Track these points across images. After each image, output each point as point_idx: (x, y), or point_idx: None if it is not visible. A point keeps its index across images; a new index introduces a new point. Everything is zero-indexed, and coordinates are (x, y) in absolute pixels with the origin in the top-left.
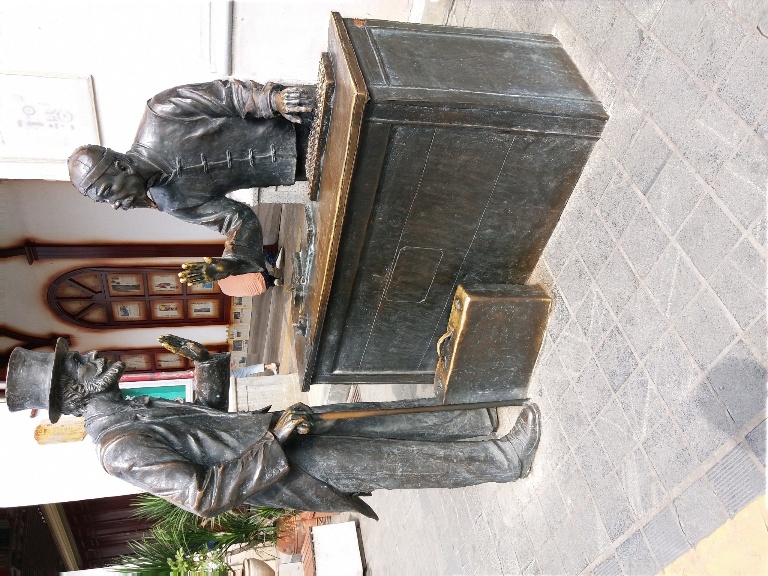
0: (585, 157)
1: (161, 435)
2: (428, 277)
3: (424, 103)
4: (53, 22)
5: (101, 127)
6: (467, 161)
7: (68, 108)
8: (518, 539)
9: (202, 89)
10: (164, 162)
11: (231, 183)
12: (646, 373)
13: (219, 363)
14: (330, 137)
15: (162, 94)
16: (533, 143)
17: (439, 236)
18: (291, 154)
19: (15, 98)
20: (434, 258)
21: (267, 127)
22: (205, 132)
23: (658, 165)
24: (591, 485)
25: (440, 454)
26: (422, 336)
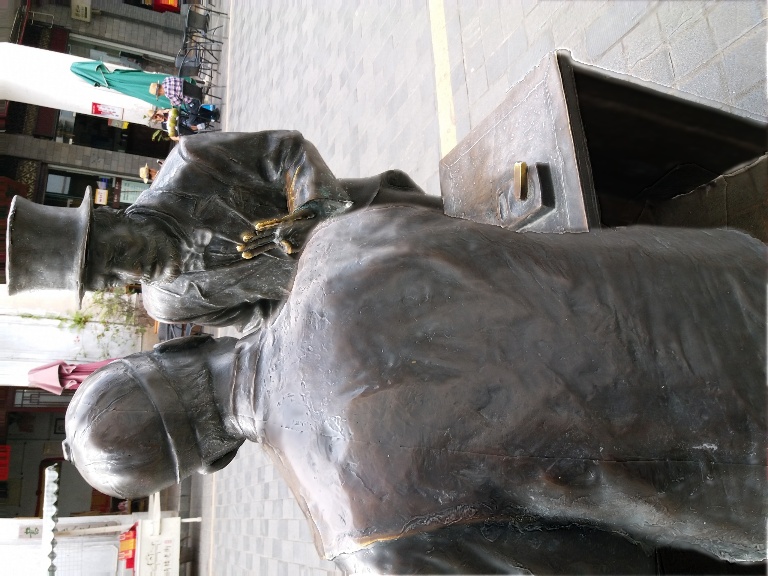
0: None
1: None
2: None
3: None
4: None
5: None
6: None
7: None
8: None
9: None
10: None
11: None
12: None
13: None
14: None
15: None
16: None
17: None
18: None
19: None
20: None
21: None
22: None
23: None
24: None
25: None
26: None
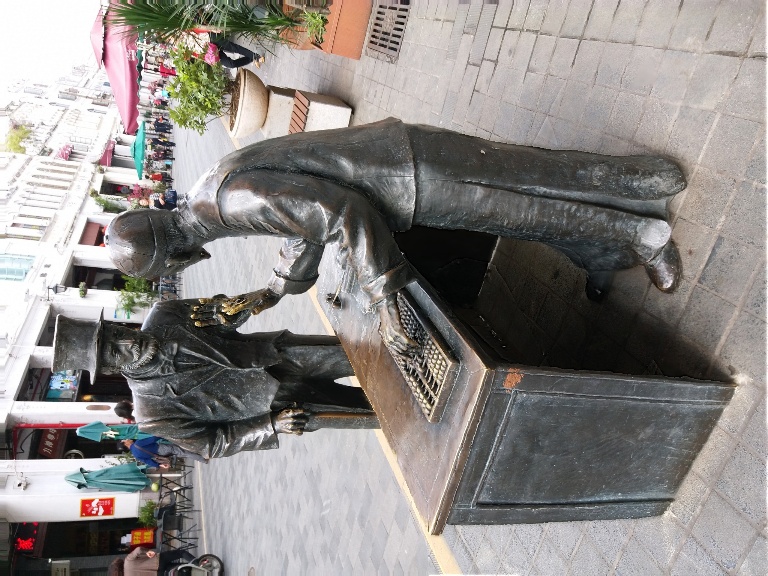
0: None
1: (186, 413)
2: None
3: None
4: None
5: None
6: None
7: None
8: None
9: (298, 222)
10: None
11: None
12: (530, 568)
13: None
14: (412, 404)
15: (241, 203)
16: None
17: None
18: None
19: None
20: None
21: None
22: None
23: None
24: None
25: None
26: None
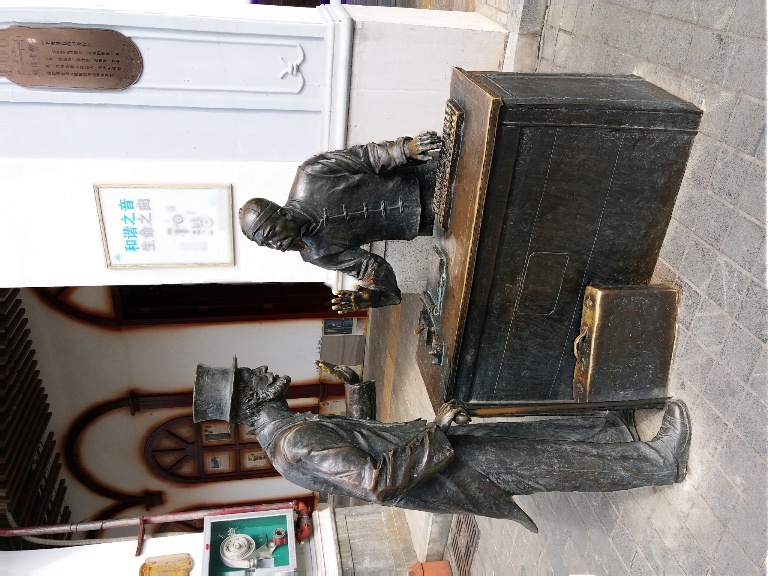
0: (687, 152)
1: (332, 429)
2: (556, 285)
3: (547, 105)
4: (205, 142)
5: (235, 231)
6: (585, 160)
7: (210, 215)
8: (686, 555)
9: (343, 152)
10: (314, 213)
11: (366, 233)
12: None
13: (368, 386)
14: (462, 159)
15: (311, 159)
16: (640, 140)
17: (564, 239)
18: (416, 205)
19: (169, 209)
20: (560, 263)
21: (396, 181)
22: (347, 186)
23: (761, 126)
24: (760, 449)
25: (593, 452)
26: (552, 355)
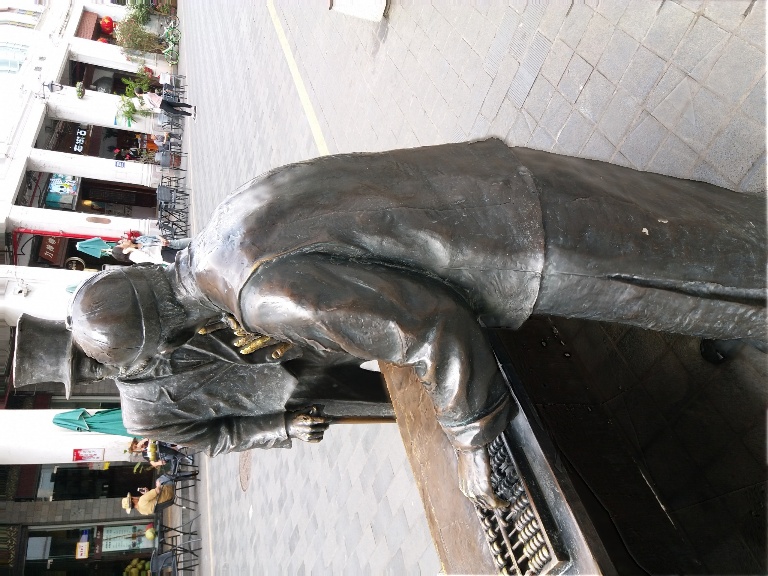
0: None
1: (184, 418)
2: None
3: None
4: None
5: None
6: None
7: None
8: None
9: (361, 346)
10: None
11: None
12: None
13: None
14: (480, 540)
15: (277, 315)
16: None
17: None
18: None
19: None
20: None
21: None
22: None
23: None
24: None
25: None
26: None
